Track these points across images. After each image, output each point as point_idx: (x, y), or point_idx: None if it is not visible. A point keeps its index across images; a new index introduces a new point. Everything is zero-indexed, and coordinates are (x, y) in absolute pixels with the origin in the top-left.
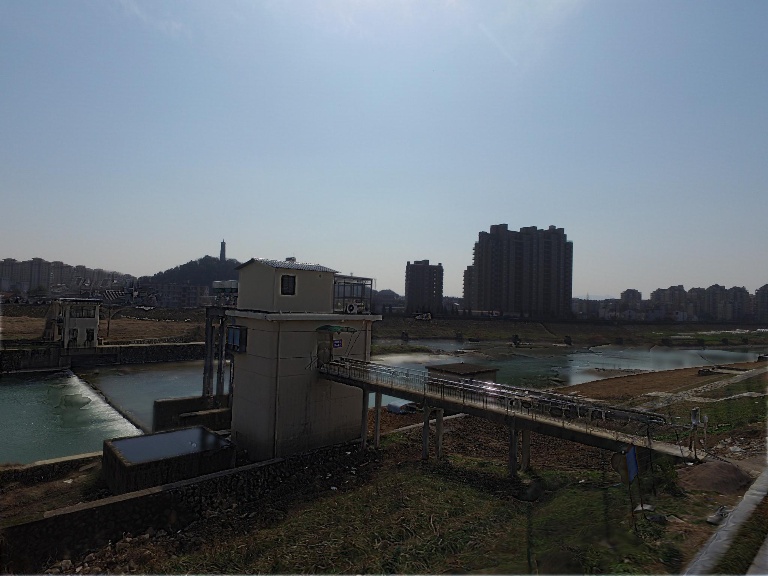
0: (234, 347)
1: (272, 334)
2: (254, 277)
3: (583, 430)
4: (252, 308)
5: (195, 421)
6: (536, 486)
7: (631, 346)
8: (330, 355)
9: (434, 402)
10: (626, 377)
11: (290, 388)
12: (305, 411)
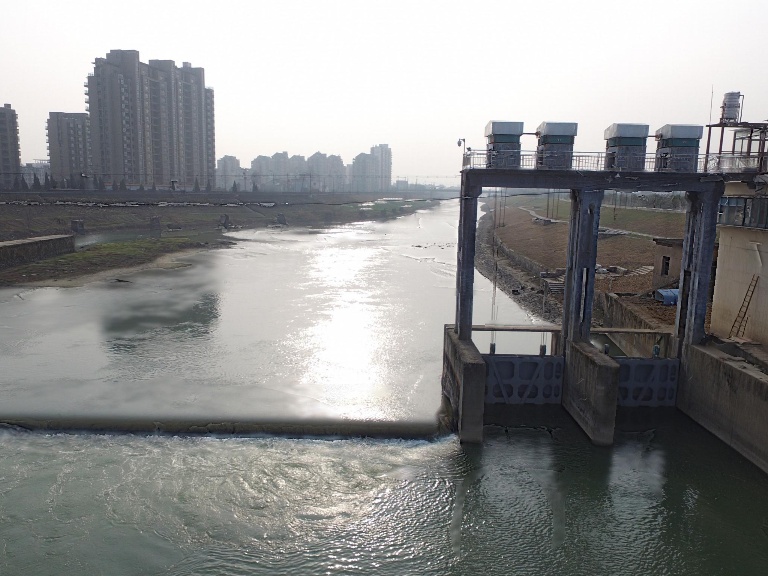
0: None
1: None
2: None
3: None
4: None
5: None
6: None
7: (389, 220)
8: None
9: None
10: (526, 248)
11: None
12: None
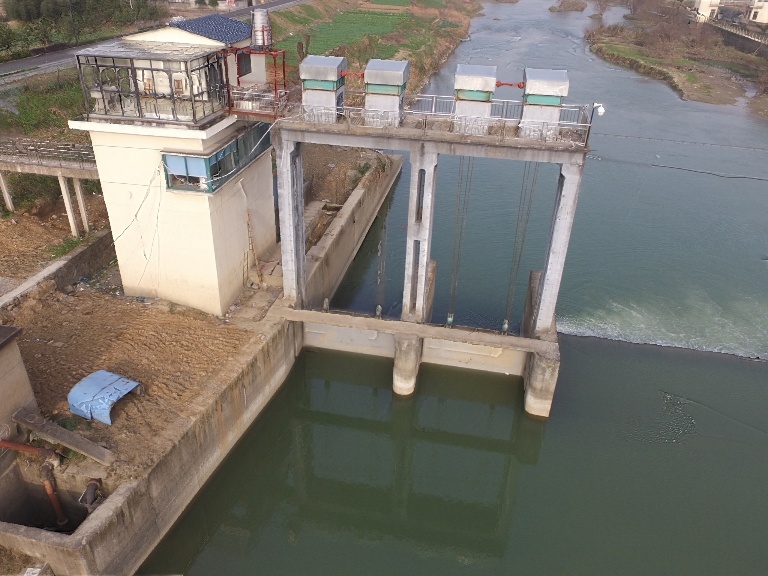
0: None
1: None
2: None
3: None
4: None
5: None
6: None
7: None
8: None
9: None
10: None
11: None
12: None
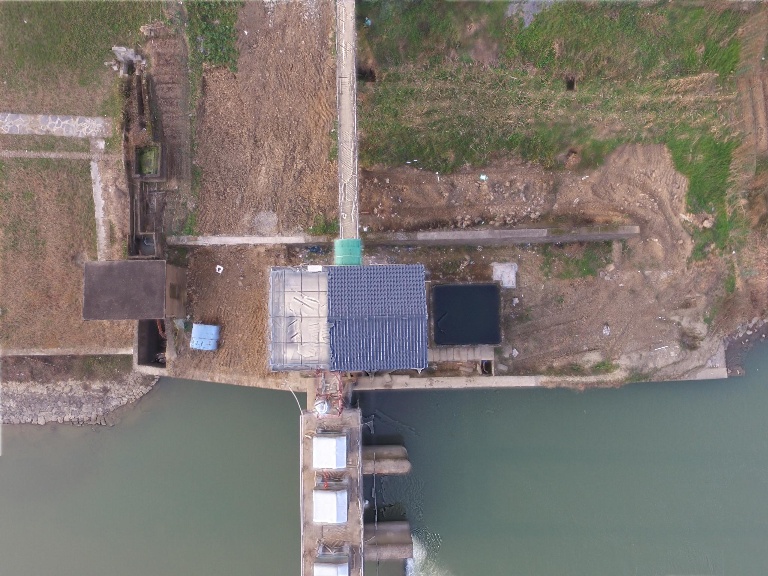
0: None
1: None
2: None
3: None
4: None
5: None
6: None
7: None
8: None
9: None
10: None
11: None
12: None
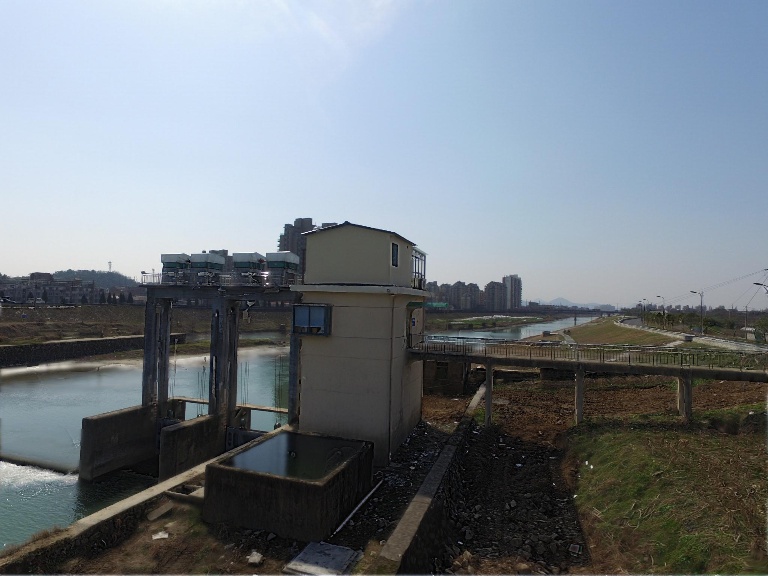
0: (311, 329)
1: (389, 310)
2: (343, 244)
3: (761, 371)
4: (341, 281)
5: (184, 435)
6: (714, 424)
7: (441, 330)
8: (409, 334)
9: (593, 367)
10: None
11: (395, 372)
12: (400, 397)
